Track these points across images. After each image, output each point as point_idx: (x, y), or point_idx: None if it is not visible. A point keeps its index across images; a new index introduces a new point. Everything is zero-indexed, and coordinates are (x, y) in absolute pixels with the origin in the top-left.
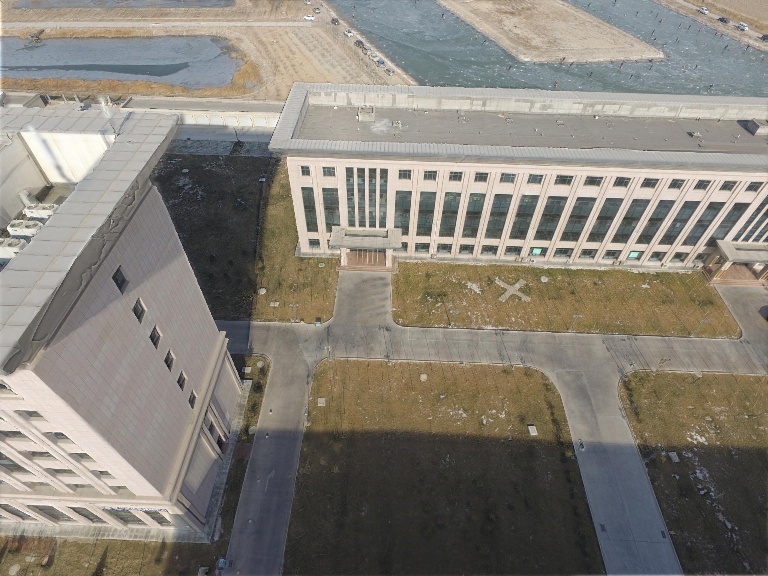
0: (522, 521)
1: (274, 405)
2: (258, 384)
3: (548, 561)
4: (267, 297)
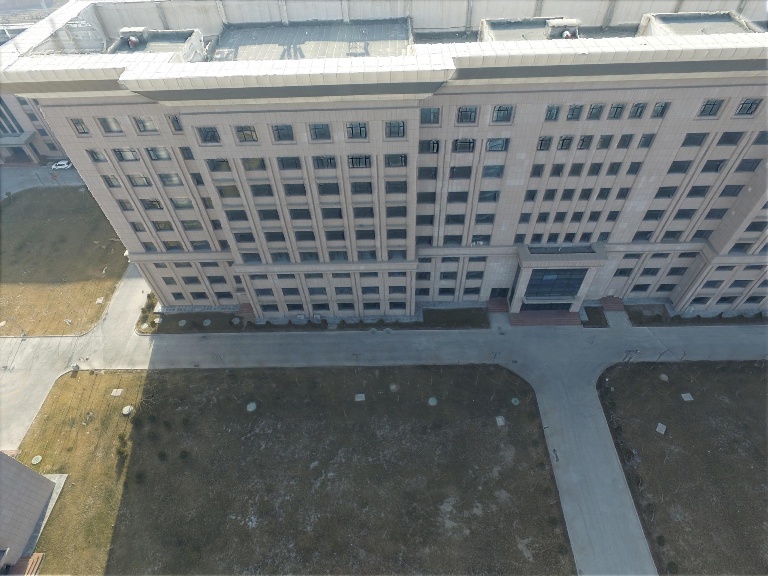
0: (2, 247)
1: (139, 296)
2: (149, 310)
3: (3, 233)
4: (123, 402)
